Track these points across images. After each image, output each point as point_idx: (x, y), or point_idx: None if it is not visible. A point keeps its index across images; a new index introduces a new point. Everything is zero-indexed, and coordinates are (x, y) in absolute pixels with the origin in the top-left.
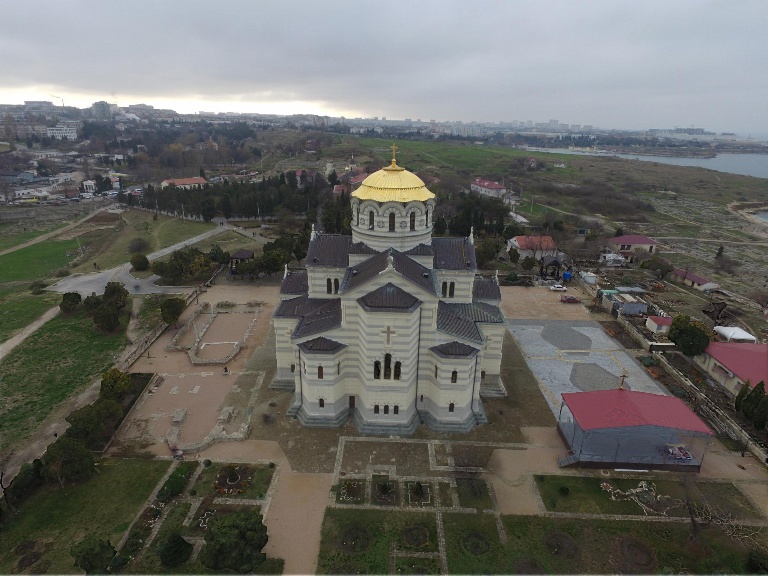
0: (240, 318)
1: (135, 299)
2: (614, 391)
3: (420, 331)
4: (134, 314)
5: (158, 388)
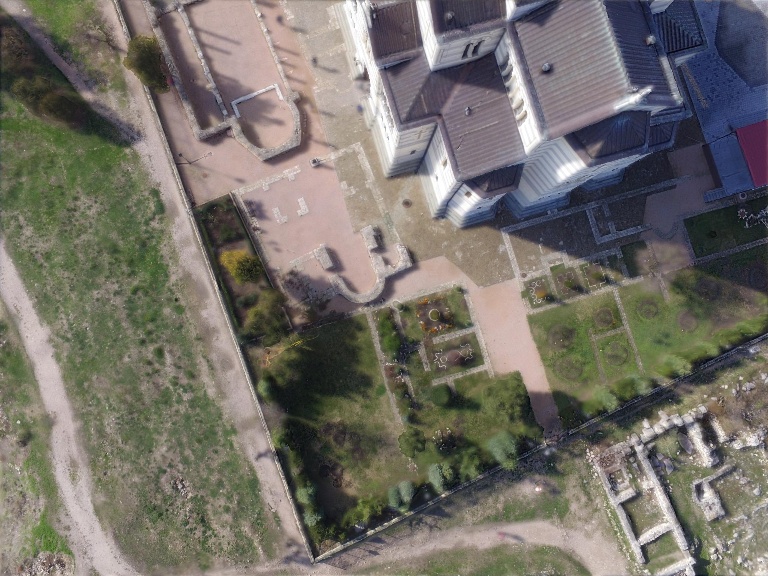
0: (230, 12)
1: (1, 1)
2: None
3: None
4: (51, 53)
5: (257, 219)
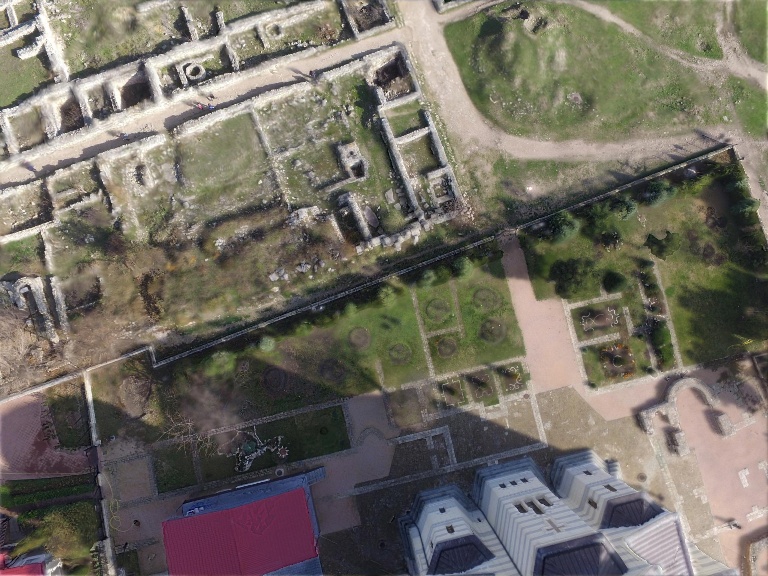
0: None
1: None
2: (253, 573)
3: (516, 568)
4: None
5: None
